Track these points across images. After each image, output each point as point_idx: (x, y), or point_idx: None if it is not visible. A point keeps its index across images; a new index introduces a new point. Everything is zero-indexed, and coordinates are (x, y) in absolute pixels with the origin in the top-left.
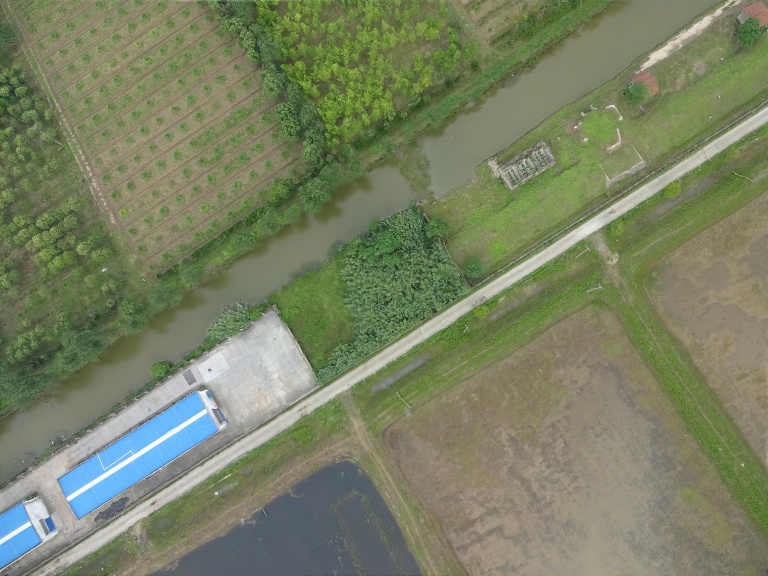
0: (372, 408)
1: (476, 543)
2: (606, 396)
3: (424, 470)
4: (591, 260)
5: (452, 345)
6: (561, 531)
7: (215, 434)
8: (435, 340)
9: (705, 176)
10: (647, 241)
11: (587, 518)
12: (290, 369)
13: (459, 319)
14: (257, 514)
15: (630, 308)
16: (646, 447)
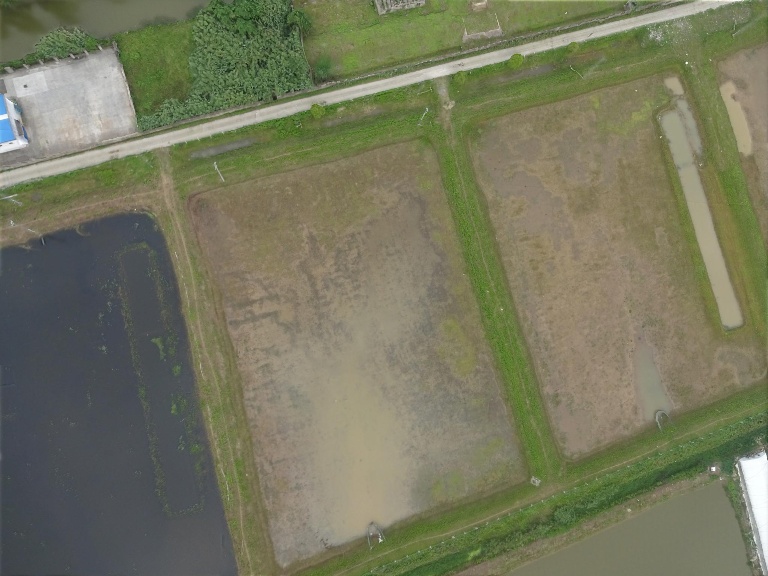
0: (186, 170)
1: (250, 322)
2: (407, 223)
3: (220, 243)
4: (430, 100)
5: (282, 135)
6: (331, 330)
7: (12, 151)
8: (267, 126)
9: (547, 62)
10: (482, 99)
11: (358, 324)
12: (113, 111)
13: (295, 113)
14: (34, 241)
15: (450, 151)
16: (428, 276)
